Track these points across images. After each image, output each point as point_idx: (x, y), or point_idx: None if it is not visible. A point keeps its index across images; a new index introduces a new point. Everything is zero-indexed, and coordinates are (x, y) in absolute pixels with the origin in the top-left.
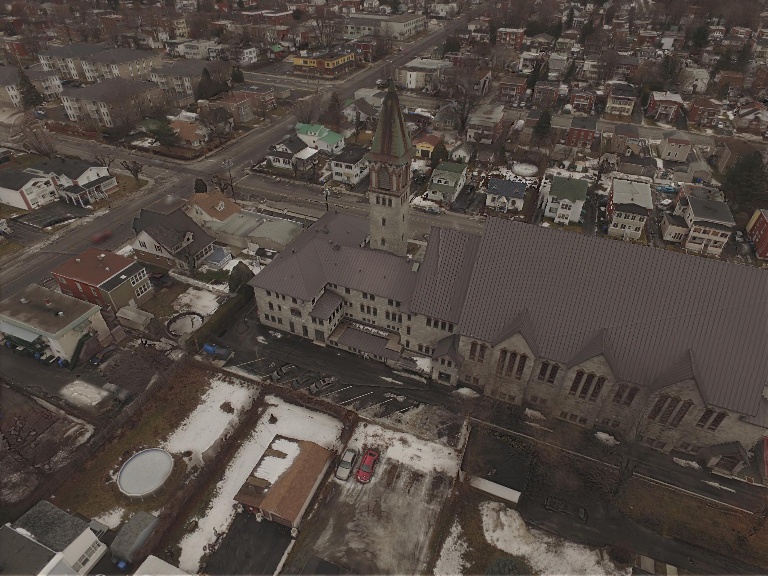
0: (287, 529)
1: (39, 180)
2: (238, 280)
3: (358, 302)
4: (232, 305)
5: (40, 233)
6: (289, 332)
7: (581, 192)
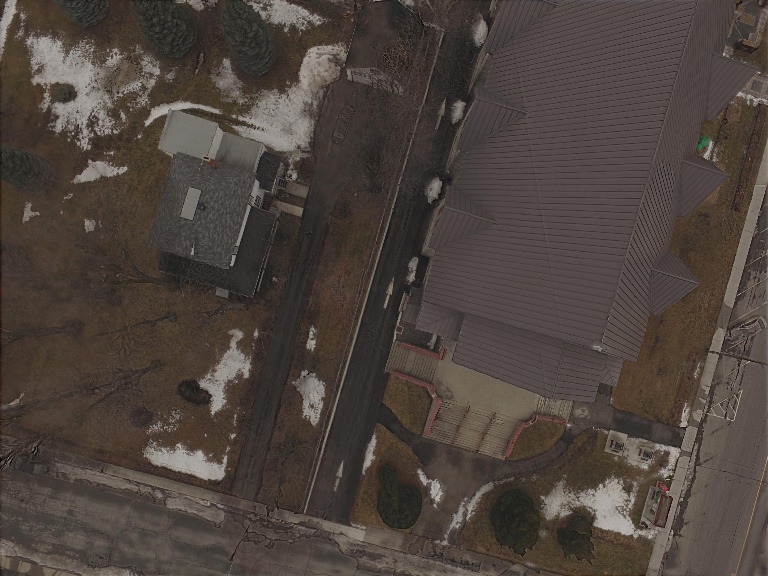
0: None
1: None
2: None
3: None
4: None
5: None
6: None
7: None
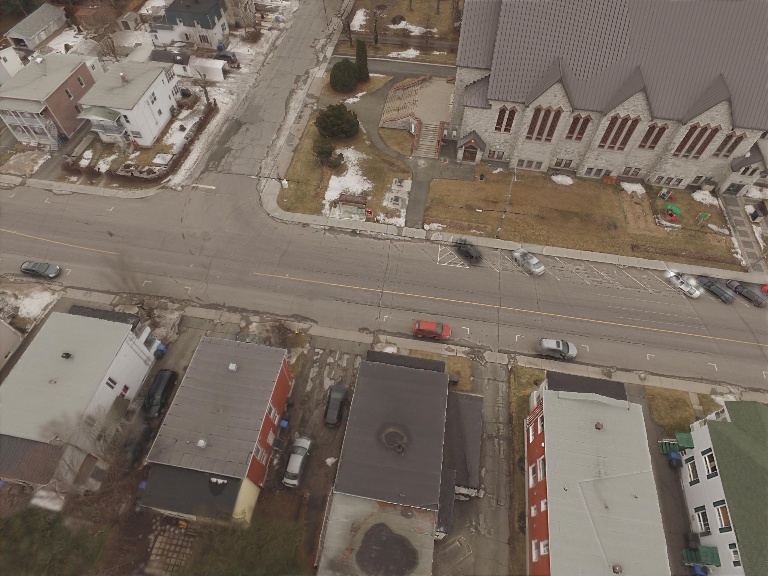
0: None
1: None
2: None
3: None
4: None
5: None
6: None
7: (738, 455)
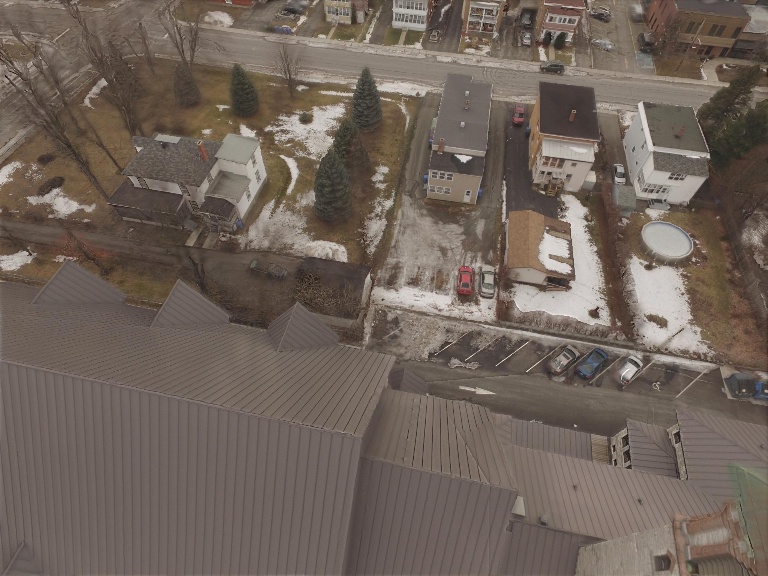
0: None
1: None
2: None
3: None
4: None
5: None
6: None
7: None
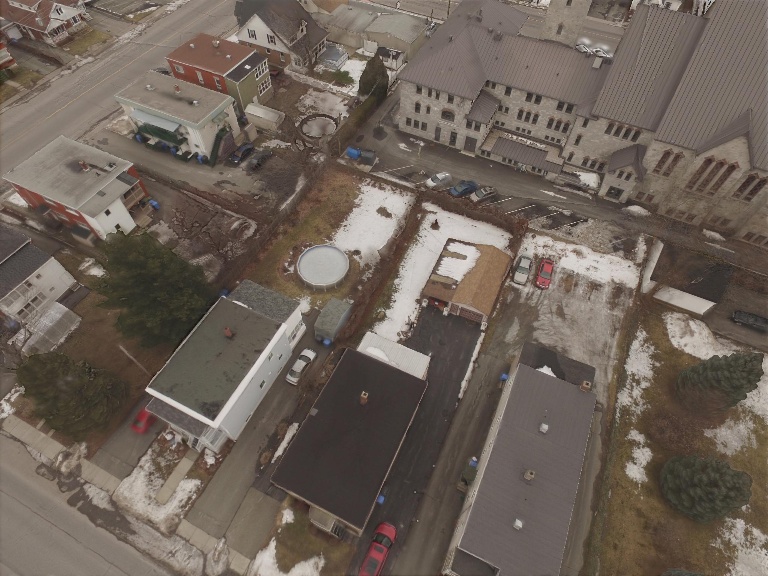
0: (475, 323)
1: None
2: (373, 78)
3: (517, 106)
4: (367, 107)
5: (123, 21)
6: (432, 140)
7: None
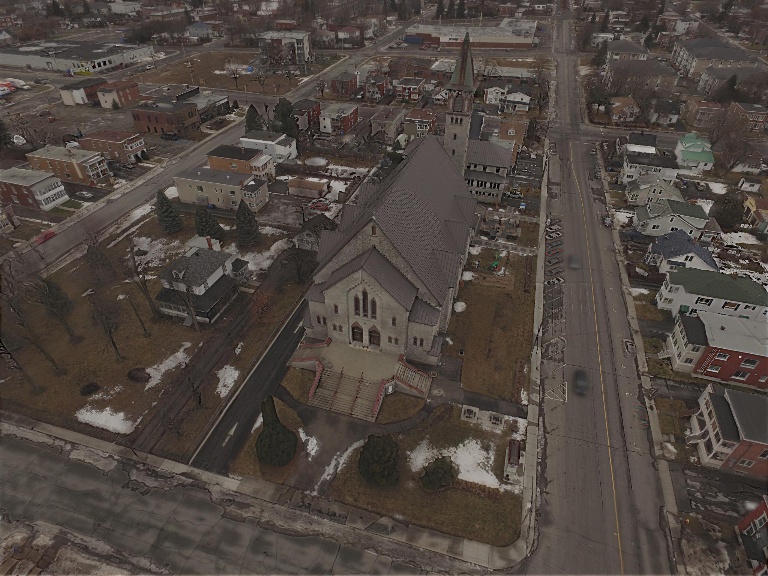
0: None
1: (500, 89)
2: None
3: None
4: None
5: None
6: None
7: (705, 288)
